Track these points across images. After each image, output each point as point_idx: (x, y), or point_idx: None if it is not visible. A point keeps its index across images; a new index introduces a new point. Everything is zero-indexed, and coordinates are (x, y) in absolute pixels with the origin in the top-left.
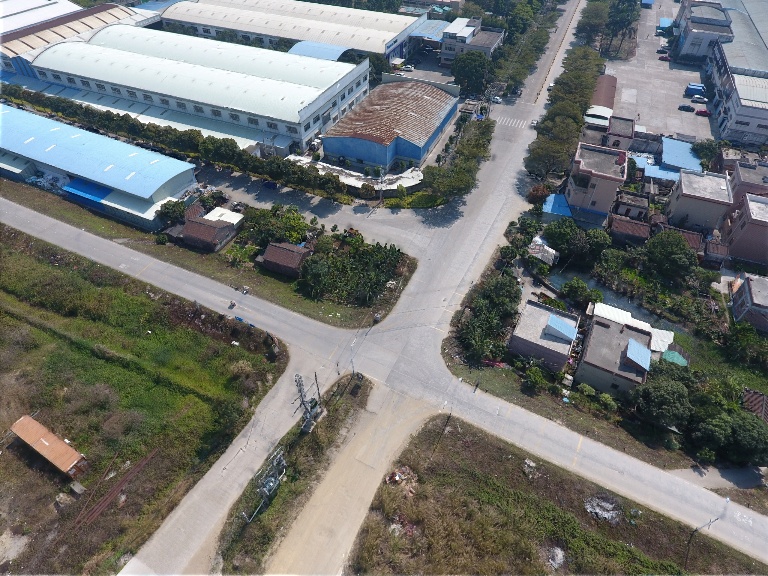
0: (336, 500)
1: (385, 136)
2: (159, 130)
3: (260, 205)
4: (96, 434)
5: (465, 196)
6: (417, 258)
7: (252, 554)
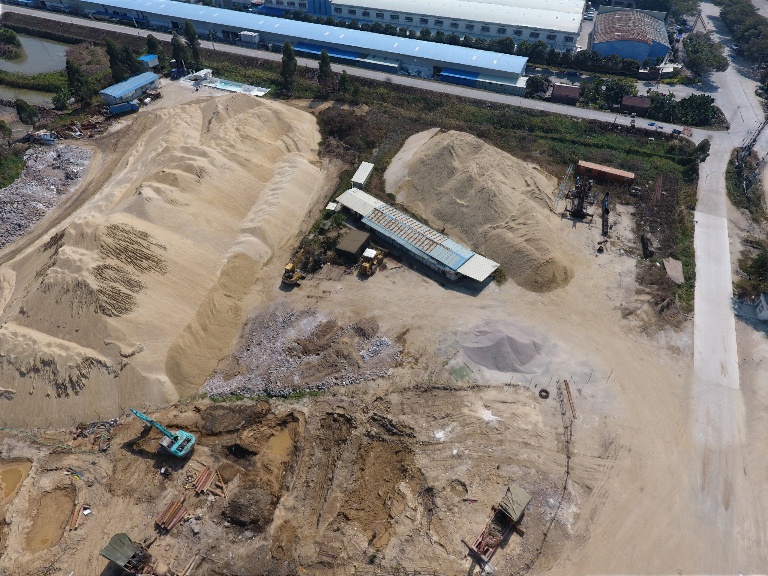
0: None
1: (646, 39)
2: (477, 39)
3: (577, 84)
4: None
5: (710, 78)
6: (715, 105)
7: (759, 207)
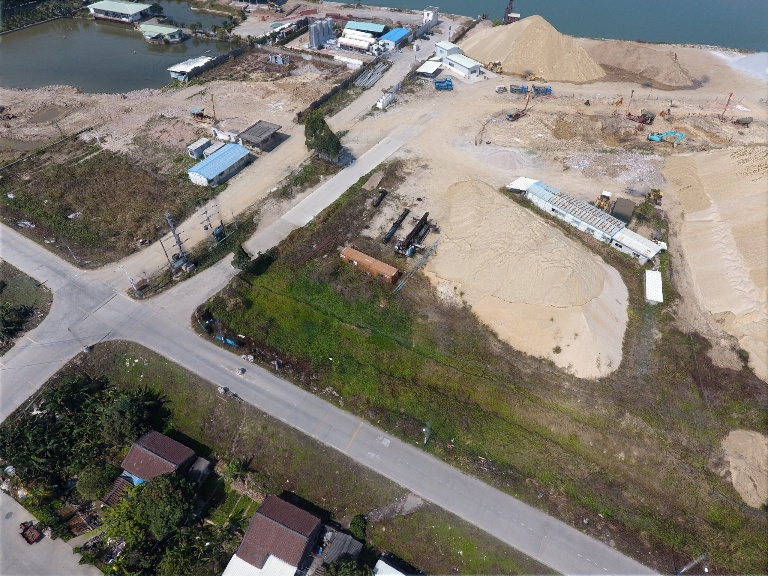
0: None
1: None
2: None
3: None
4: (344, 275)
5: None
6: None
7: None
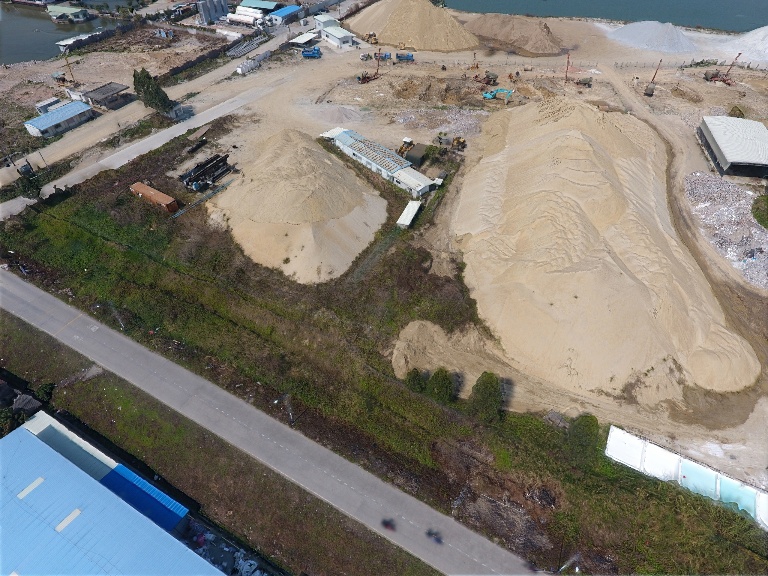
0: (1, 179)
1: None
2: None
3: None
4: None
5: None
6: None
7: None
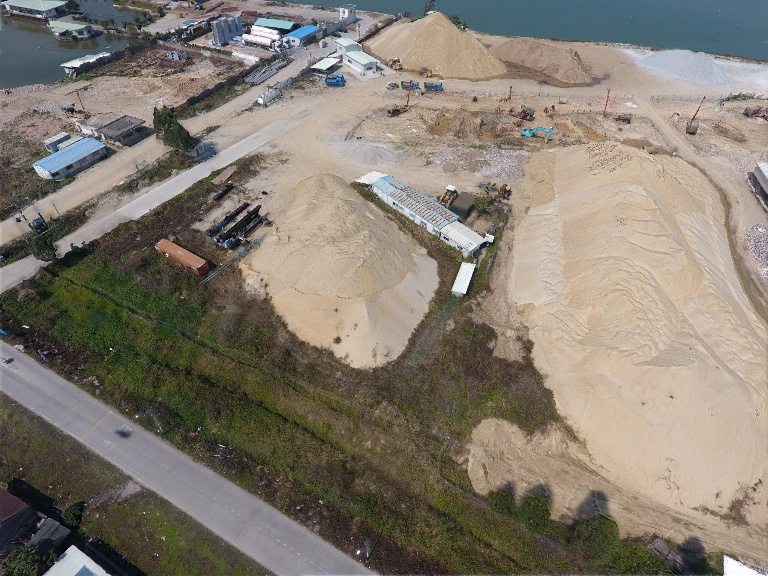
0: (9, 232)
1: None
2: None
3: None
4: (155, 267)
5: None
6: None
7: None
